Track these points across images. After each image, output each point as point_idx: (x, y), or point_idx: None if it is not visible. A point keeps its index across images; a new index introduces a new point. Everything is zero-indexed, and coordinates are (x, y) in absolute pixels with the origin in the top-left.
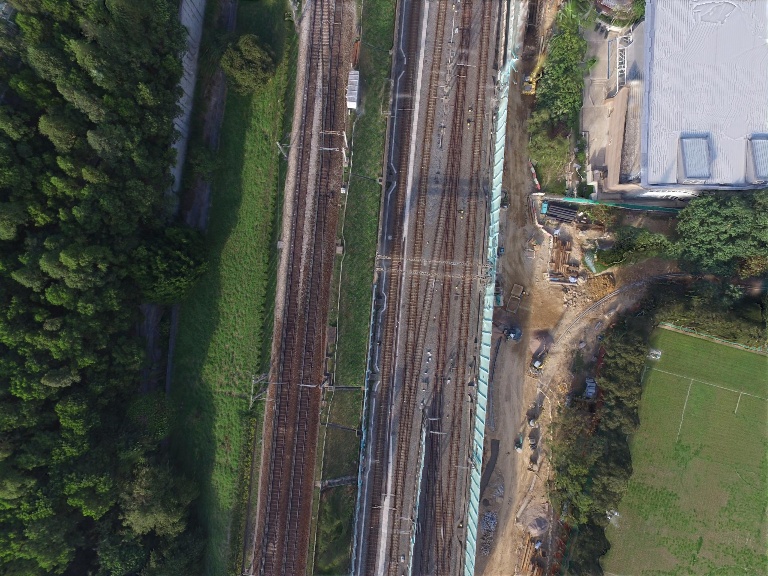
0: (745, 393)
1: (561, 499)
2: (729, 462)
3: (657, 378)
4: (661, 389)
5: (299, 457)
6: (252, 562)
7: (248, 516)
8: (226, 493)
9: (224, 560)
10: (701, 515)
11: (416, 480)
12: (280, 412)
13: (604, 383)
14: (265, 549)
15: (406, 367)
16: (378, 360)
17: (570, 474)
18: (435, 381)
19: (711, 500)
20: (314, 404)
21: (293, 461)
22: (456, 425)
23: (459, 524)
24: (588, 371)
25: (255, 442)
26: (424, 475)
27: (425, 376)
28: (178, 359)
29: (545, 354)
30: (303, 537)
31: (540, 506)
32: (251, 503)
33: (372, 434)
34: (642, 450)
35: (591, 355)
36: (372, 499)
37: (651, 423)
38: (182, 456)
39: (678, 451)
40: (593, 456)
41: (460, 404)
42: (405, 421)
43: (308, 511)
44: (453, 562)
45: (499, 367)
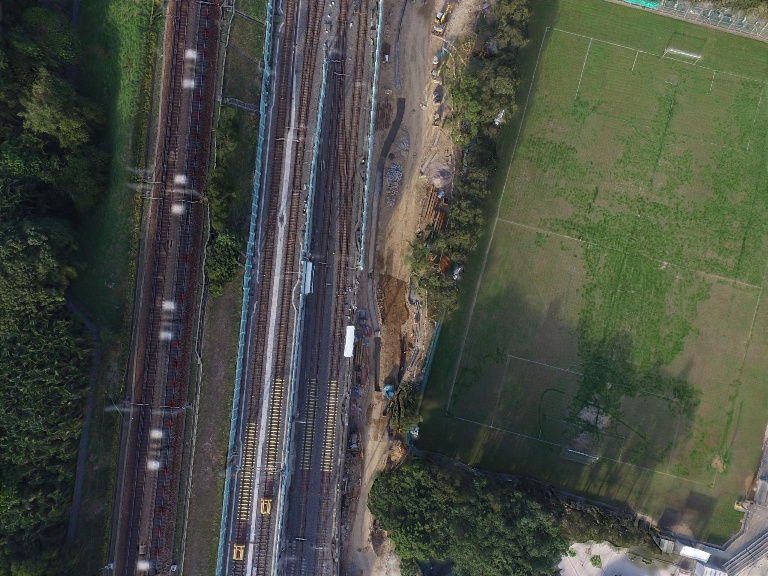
0: (642, 51)
1: (463, 148)
2: (625, 117)
3: (558, 38)
4: (561, 48)
5: (199, 71)
6: (154, 169)
7: (150, 127)
8: (128, 105)
9: (126, 164)
10: (597, 167)
11: (317, 110)
12: (180, 28)
13: (497, 8)
14: (167, 158)
15: (309, 9)
16: (282, 3)
17: (462, 88)
18: (338, 24)
19: (607, 153)
20: (213, 20)
21: (193, 74)
22: (359, 67)
23: (362, 161)
24: (491, 31)
25: (156, 57)
26: (328, 115)
27: (328, 19)
28: (86, 6)
29: (449, 14)
30: (203, 146)
31: (444, 160)
32: (153, 115)
33: (276, 72)
34: (542, 107)
35: (494, 16)
36: (276, 132)
37: (551, 81)
38: (90, 93)
39: (577, 107)
40: (484, 71)
41: (363, 47)
42: (308, 60)
43: (208, 122)
44: (356, 197)
45: (405, 28)
